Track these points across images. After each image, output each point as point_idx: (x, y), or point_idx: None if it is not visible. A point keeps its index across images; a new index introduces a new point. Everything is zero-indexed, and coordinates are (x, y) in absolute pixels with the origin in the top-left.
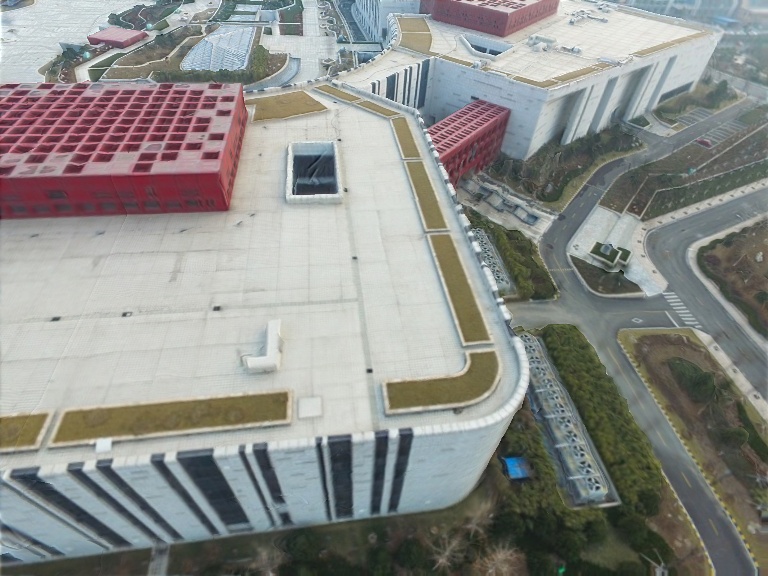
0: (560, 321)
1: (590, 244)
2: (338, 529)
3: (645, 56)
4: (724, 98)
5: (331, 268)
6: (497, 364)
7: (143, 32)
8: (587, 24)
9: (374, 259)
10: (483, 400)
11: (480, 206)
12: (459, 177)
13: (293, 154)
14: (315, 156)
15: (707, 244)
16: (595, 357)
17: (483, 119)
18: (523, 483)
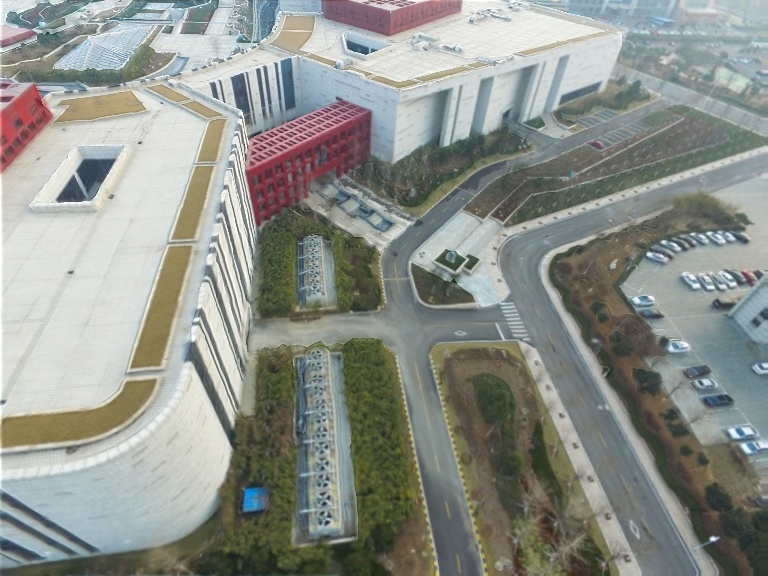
0: (374, 334)
1: (438, 251)
2: (27, 572)
3: (529, 55)
4: (634, 99)
5: (35, 284)
6: (150, 394)
7: (30, 30)
8: (487, 23)
9: (91, 273)
10: (107, 437)
11: (332, 211)
12: (308, 181)
13: (82, 158)
14: (108, 160)
15: (565, 251)
16: (385, 375)
17: (335, 120)
18: (245, 518)
